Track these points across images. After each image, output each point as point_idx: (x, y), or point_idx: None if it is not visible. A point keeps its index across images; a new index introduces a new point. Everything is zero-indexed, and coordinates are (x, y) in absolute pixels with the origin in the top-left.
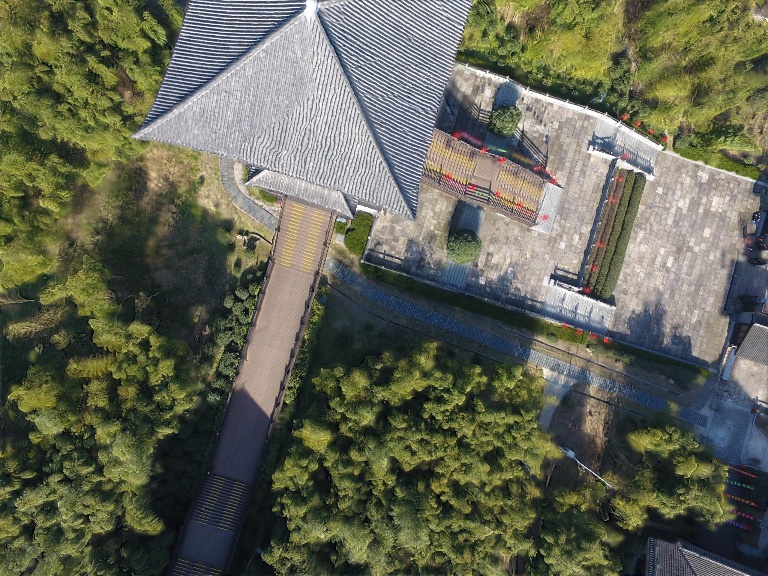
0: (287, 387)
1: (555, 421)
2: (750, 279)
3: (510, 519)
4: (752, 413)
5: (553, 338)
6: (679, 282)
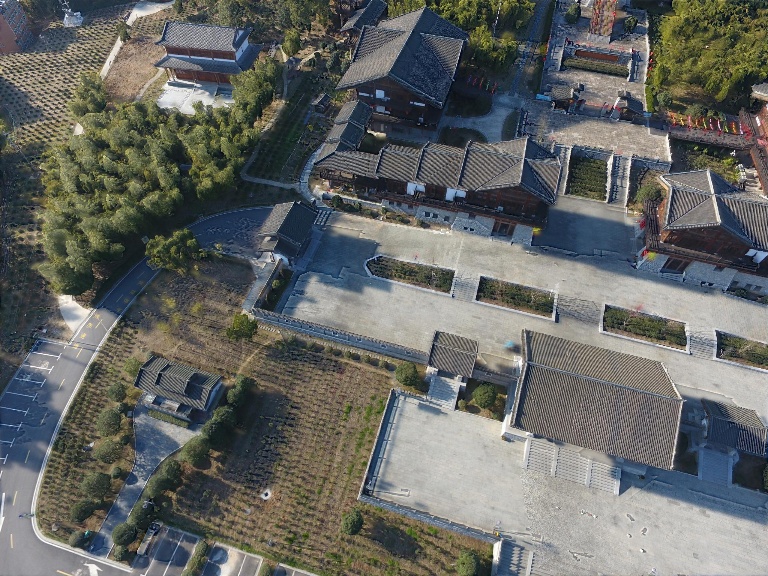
0: None
1: None
2: None
3: None
4: None
5: (541, 43)
6: None
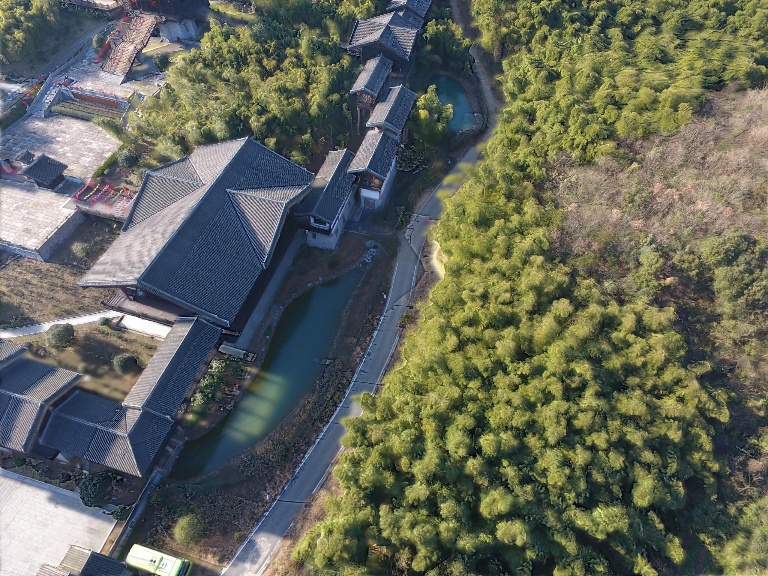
0: (65, 3)
1: None
2: None
3: None
4: None
5: (39, 82)
6: (43, 142)
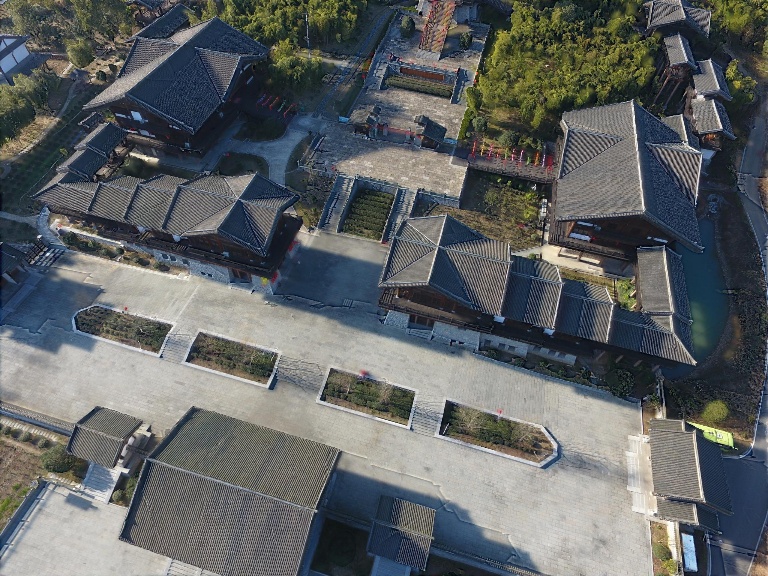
0: None
1: (323, 63)
2: (398, 136)
3: (292, 8)
4: None
5: (365, 59)
6: (395, 110)
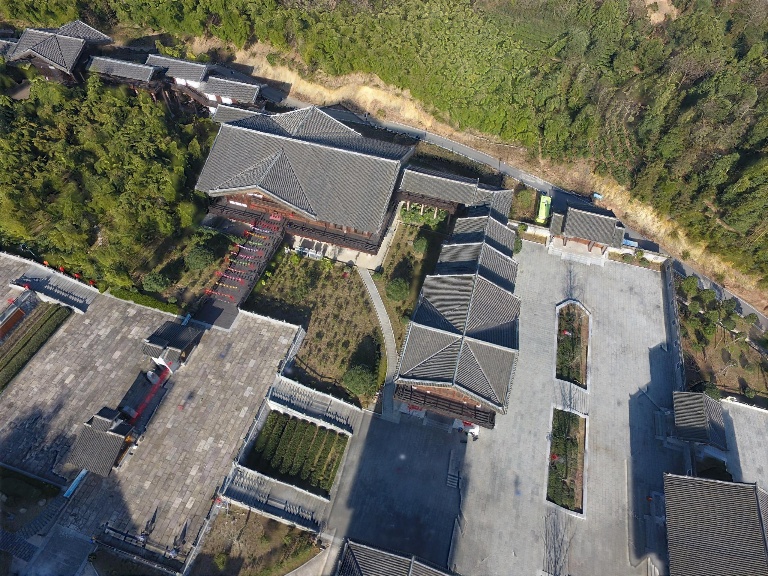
0: None
1: None
2: (144, 396)
3: None
4: (93, 543)
5: None
6: (70, 397)
